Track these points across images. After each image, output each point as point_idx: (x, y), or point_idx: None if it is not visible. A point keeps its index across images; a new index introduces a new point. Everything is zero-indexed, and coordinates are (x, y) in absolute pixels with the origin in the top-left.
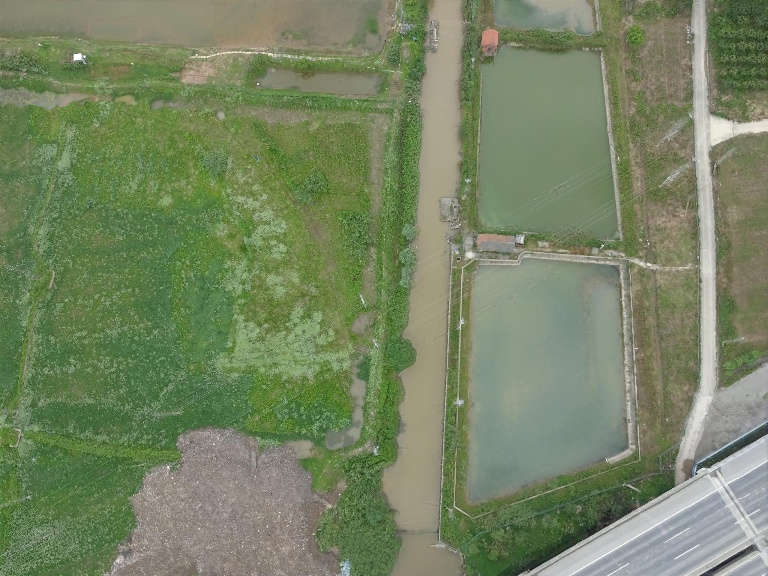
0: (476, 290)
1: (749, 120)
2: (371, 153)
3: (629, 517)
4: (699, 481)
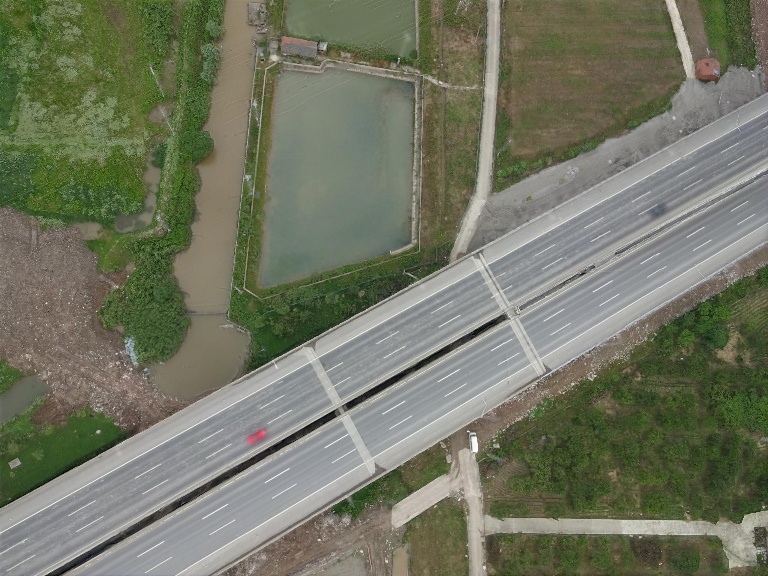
0: (279, 93)
1: None
2: None
3: (401, 291)
4: (464, 262)
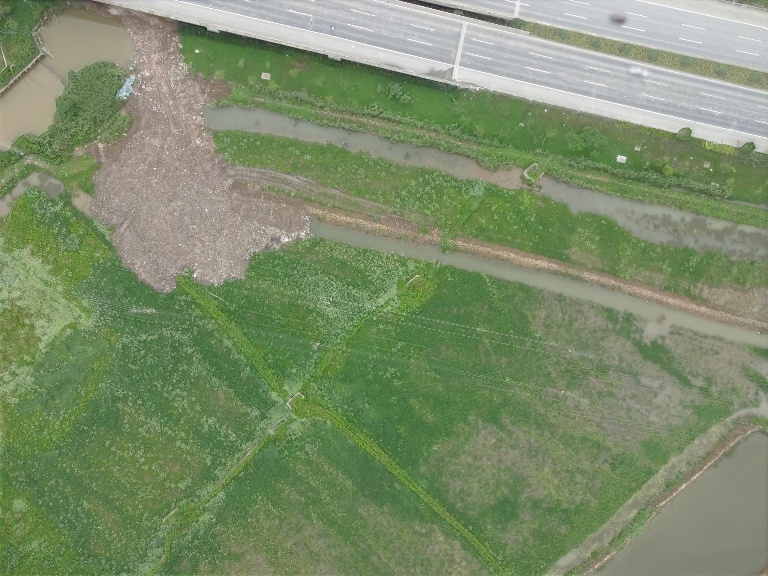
0: None
1: None
2: None
3: None
4: None
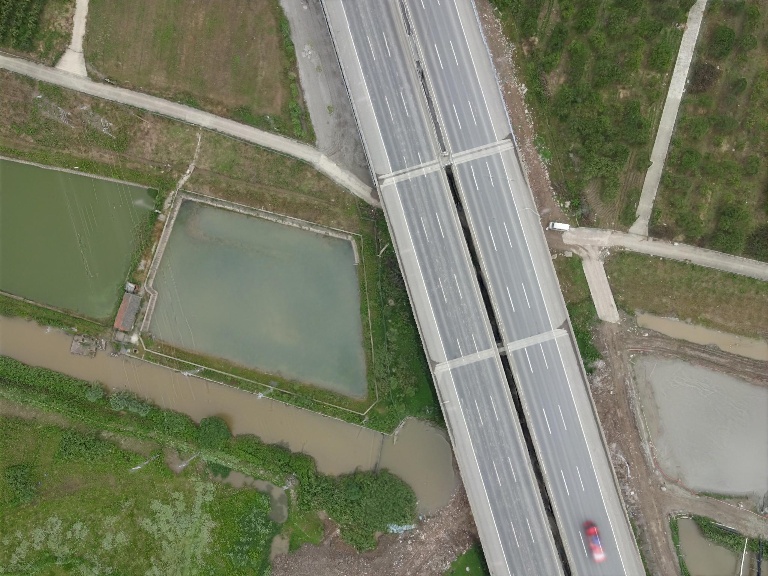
0: (172, 341)
1: (70, 34)
2: (2, 412)
3: (400, 267)
4: (384, 196)
